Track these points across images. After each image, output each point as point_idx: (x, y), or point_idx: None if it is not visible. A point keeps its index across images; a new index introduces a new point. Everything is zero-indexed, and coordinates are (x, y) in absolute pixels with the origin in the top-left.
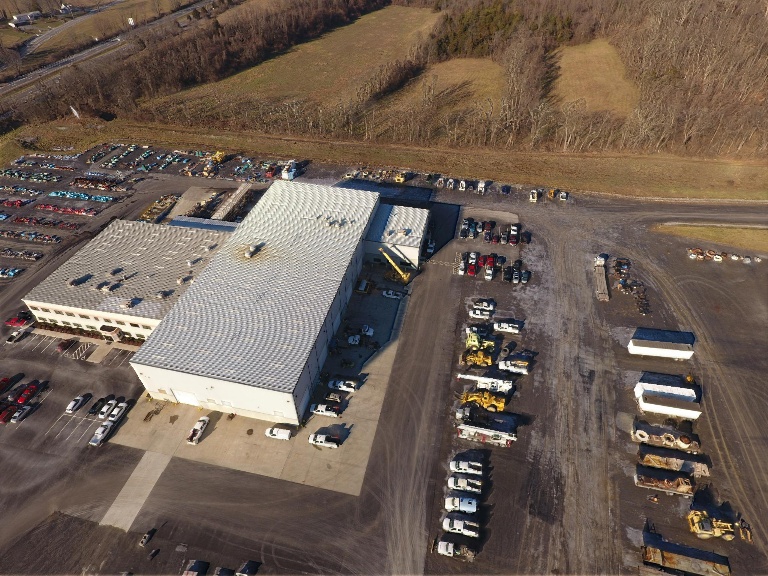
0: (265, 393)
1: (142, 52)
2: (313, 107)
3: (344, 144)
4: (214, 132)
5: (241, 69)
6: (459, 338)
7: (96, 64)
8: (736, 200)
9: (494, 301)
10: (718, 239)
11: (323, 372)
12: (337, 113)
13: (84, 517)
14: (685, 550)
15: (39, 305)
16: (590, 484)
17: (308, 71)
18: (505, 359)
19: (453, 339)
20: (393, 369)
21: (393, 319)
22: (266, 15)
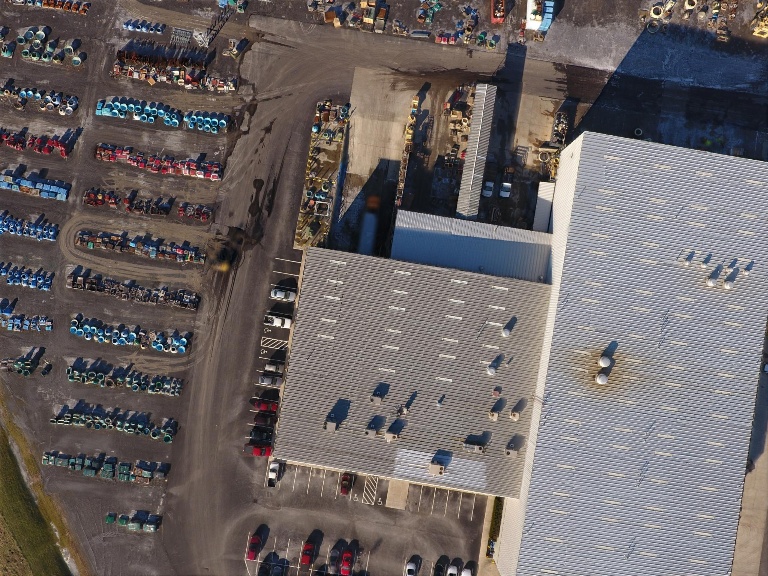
0: None
1: None
2: None
3: None
4: None
5: None
6: None
7: None
8: None
9: None
10: None
11: None
12: None
13: None
14: None
15: None
16: None
17: None
18: None
19: None
20: None
21: (767, 413)
22: None
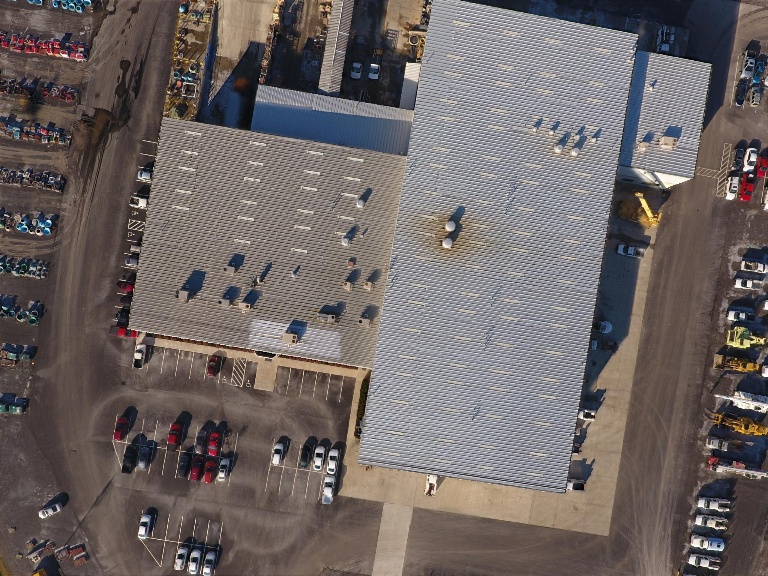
0: None
1: None
2: None
3: None
4: None
5: None
6: (716, 326)
7: None
8: None
9: None
10: None
11: None
12: None
13: (354, 572)
14: None
15: None
16: None
17: None
18: None
19: (709, 328)
20: (635, 381)
21: (632, 296)
22: None
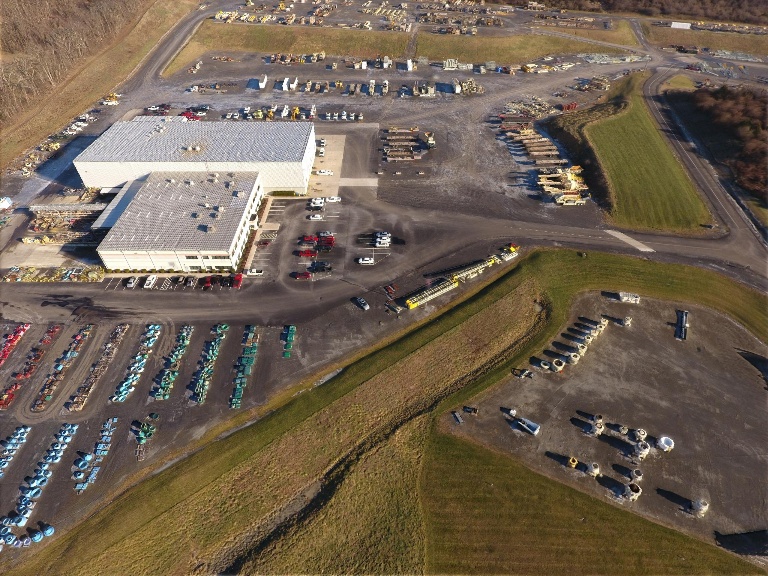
0: None
1: None
2: None
3: None
4: None
5: None
6: None
7: None
8: (145, 57)
9: (224, 114)
10: (180, 66)
11: None
12: None
13: (377, 191)
14: (347, 89)
15: None
16: None
17: None
18: None
19: None
20: None
21: None
22: None
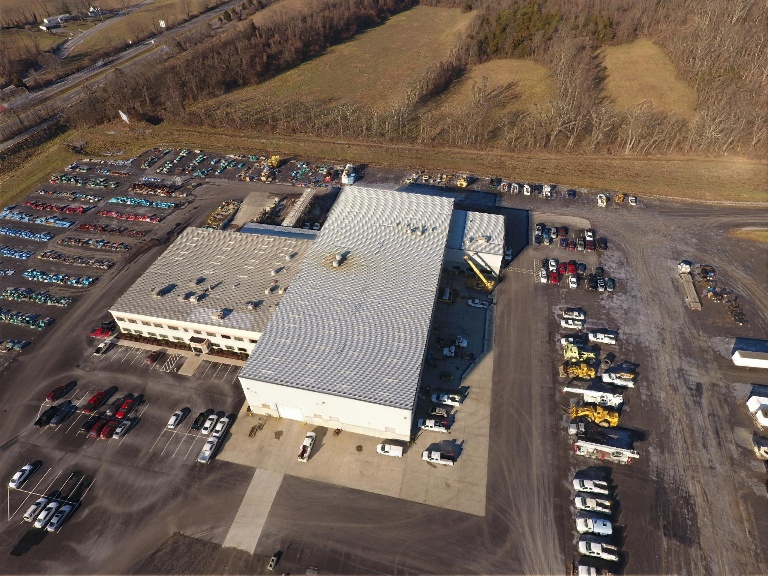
0: (381, 409)
1: (184, 55)
2: (360, 110)
3: (399, 148)
4: (264, 136)
5: (280, 71)
6: (555, 349)
7: (141, 68)
8: None
9: (583, 310)
10: None
11: (423, 385)
12: (386, 116)
13: (205, 538)
14: None
15: (126, 316)
16: (721, 504)
17: (348, 73)
18: (606, 371)
19: (549, 350)
20: (493, 382)
21: (483, 329)
22: (302, 17)
